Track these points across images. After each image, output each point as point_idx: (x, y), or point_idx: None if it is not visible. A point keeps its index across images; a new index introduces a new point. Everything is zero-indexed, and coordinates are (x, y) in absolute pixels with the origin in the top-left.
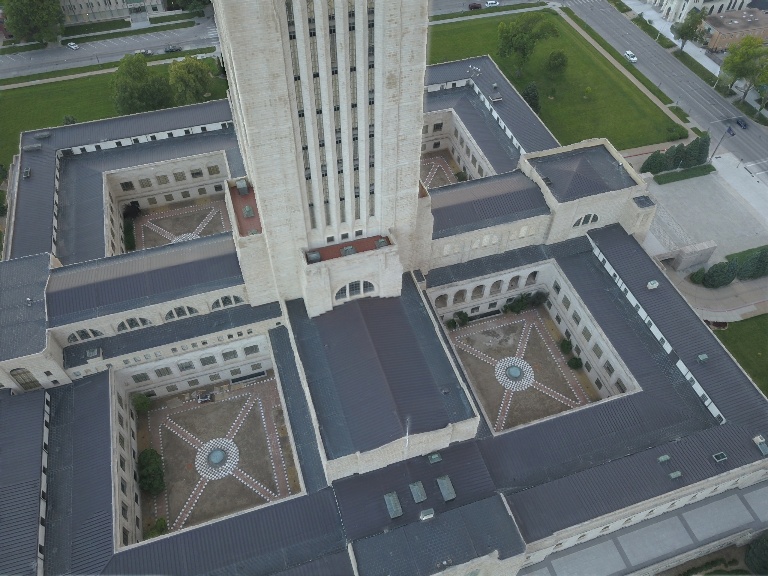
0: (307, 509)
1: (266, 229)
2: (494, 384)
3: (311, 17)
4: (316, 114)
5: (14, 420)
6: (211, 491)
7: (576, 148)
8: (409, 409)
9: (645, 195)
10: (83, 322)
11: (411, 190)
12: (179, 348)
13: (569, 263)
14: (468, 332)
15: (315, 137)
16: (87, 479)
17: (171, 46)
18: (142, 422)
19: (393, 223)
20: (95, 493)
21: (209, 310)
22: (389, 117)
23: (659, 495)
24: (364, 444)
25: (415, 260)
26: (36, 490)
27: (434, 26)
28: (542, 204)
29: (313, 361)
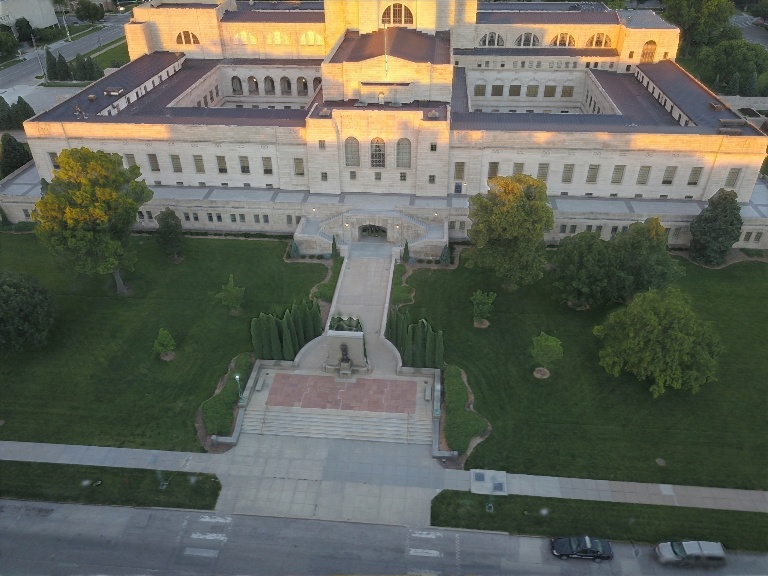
0: None
1: None
2: None
3: None
4: None
5: None
6: None
7: (162, 14)
8: None
9: None
10: None
11: None
12: None
13: None
14: None
15: None
16: None
17: (588, 543)
18: None
19: None
20: None
21: None
22: None
23: (312, 2)
24: None
25: None
26: None
27: None
28: None
29: None
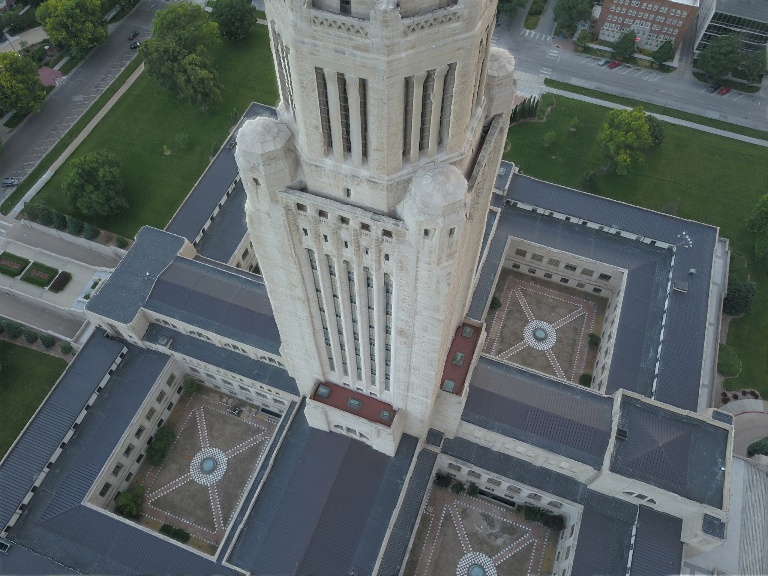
0: (208, 573)
1: (288, 355)
2: (451, 569)
3: (332, 265)
4: (336, 316)
5: (93, 358)
6: (188, 488)
7: (692, 416)
8: (311, 569)
9: (722, 521)
10: (165, 317)
11: (423, 398)
12: (222, 372)
13: (595, 522)
14: (470, 503)
15: (333, 329)
16: (105, 433)
17: None
18: (185, 398)
19: (404, 406)
20: (102, 448)
21: (257, 358)
22: (401, 352)
23: None
24: (260, 569)
25: (440, 426)
26: (71, 422)
27: (720, 138)
28: (600, 454)
29: (283, 466)
